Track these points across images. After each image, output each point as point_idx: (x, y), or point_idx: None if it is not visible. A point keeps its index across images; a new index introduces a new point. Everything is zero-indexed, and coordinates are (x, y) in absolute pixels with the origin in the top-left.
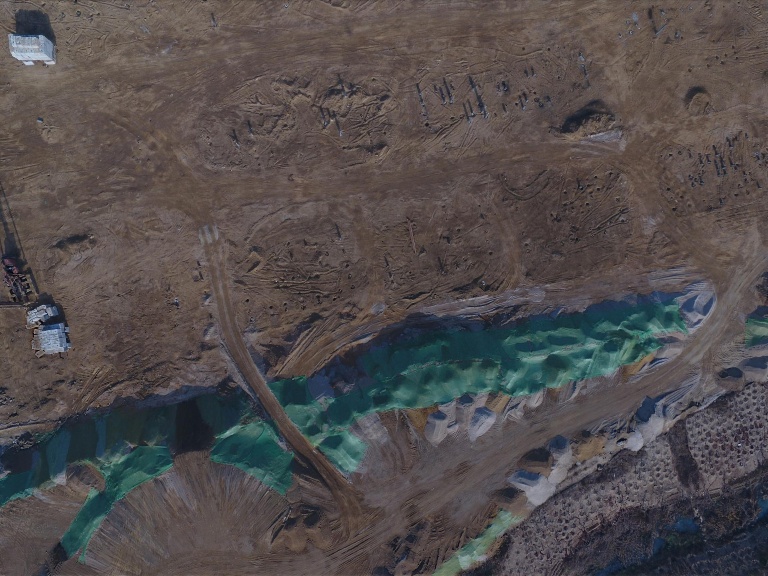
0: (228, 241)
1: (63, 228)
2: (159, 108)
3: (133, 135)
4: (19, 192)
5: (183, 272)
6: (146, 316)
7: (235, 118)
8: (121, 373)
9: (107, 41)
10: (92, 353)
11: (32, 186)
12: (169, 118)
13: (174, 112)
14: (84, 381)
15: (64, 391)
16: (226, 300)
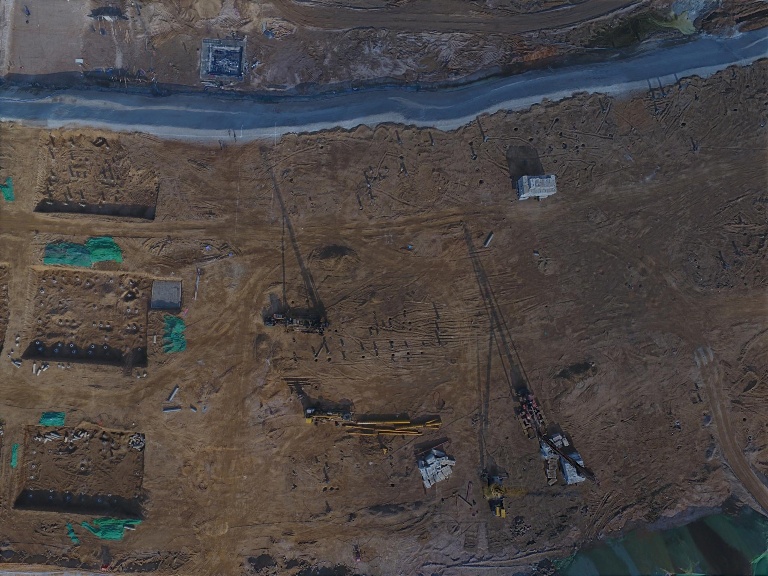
0: (723, 362)
1: (564, 357)
2: (647, 234)
3: (624, 262)
4: (520, 324)
5: (682, 395)
6: (651, 440)
7: (720, 240)
8: (630, 497)
9: (593, 171)
10: (601, 479)
11: (532, 318)
12: (657, 243)
13: (661, 237)
14: (595, 506)
15: (577, 517)
16: (725, 420)
